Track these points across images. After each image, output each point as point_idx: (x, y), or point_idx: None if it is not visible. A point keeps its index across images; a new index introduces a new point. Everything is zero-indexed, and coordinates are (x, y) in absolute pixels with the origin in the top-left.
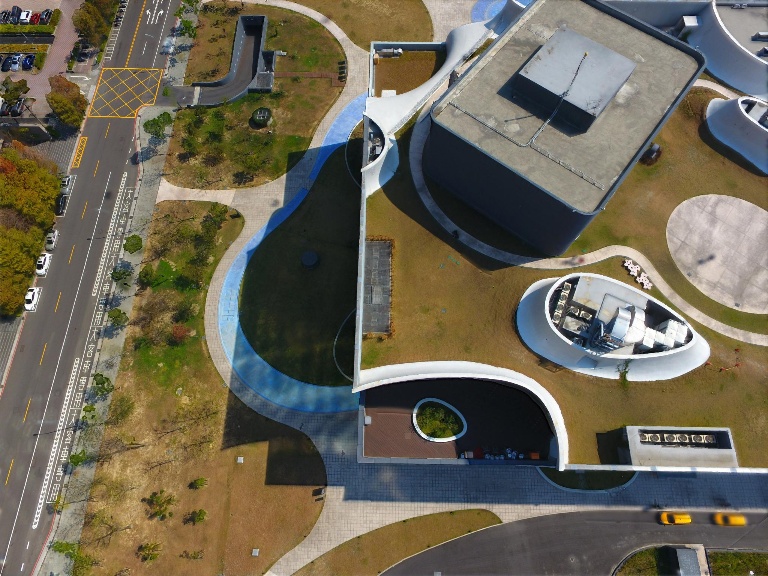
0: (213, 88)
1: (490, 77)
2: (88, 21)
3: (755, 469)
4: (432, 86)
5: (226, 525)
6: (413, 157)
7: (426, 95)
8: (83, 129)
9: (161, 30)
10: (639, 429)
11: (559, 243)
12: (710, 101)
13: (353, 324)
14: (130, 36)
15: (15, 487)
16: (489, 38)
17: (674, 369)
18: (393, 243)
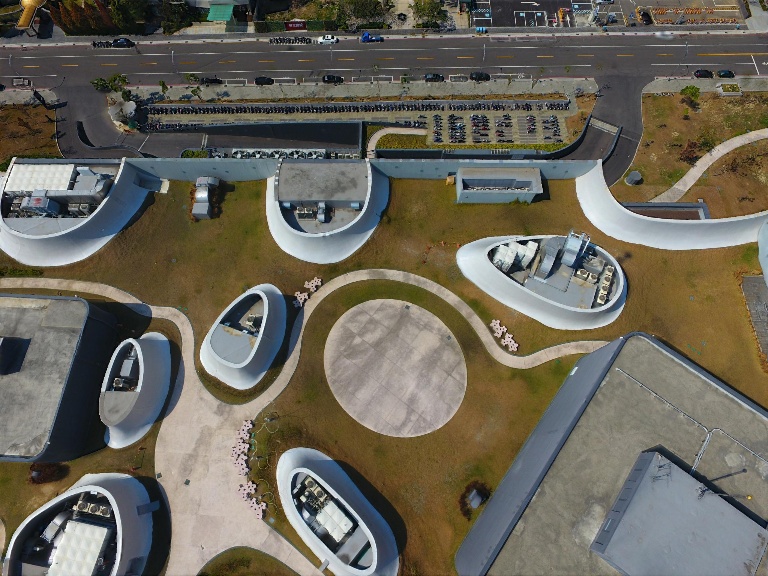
0: None
1: None
2: None
3: (455, 162)
4: None
5: None
6: None
7: None
8: None
9: None
10: (533, 191)
11: None
12: None
13: None
14: None
15: None
16: None
17: None
18: None
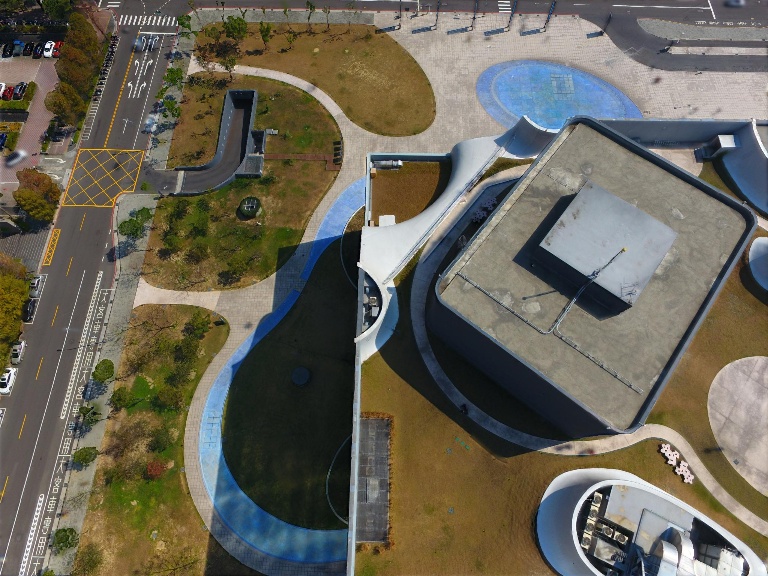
0: (198, 172)
1: (505, 238)
2: (62, 103)
3: None
4: (436, 216)
5: None
6: (415, 307)
7: (429, 227)
8: (56, 220)
9: (143, 105)
10: None
11: None
12: (753, 241)
13: (348, 454)
14: (110, 112)
15: None
16: (500, 157)
17: None
18: (392, 424)
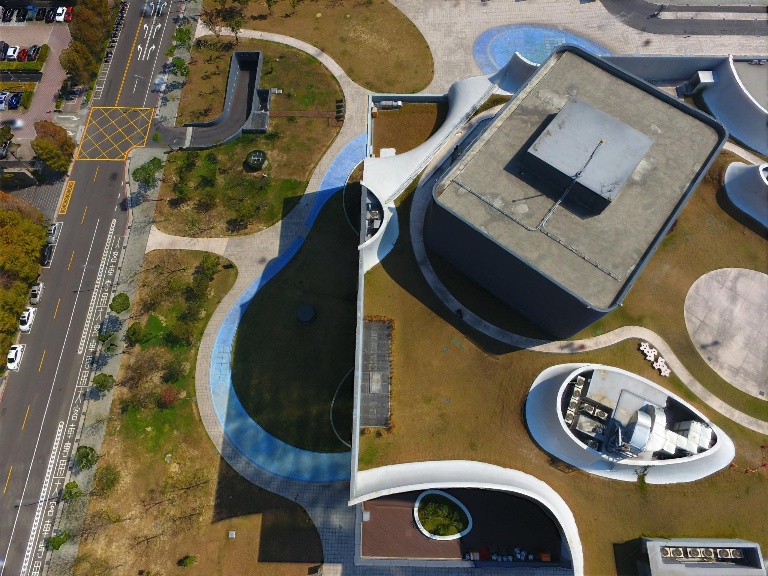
0: (206, 128)
1: (496, 150)
2: (76, 61)
3: None
4: (434, 146)
5: None
6: (414, 226)
7: (427, 156)
8: (71, 173)
9: (153, 66)
10: (660, 545)
11: (571, 329)
12: (728, 165)
13: (351, 384)
14: (120, 73)
15: None
16: (493, 93)
17: (696, 471)
18: (393, 325)
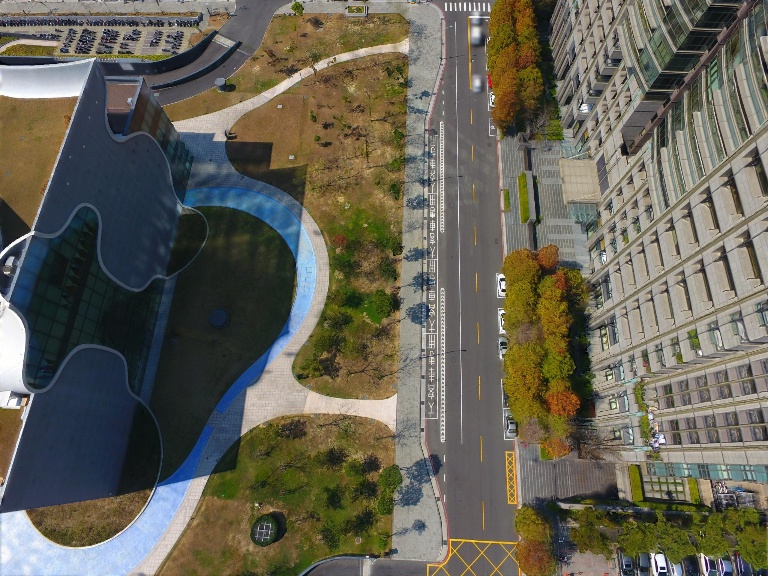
0: None
1: None
2: None
3: None
4: None
5: (302, 121)
6: None
7: None
8: None
9: None
10: None
11: None
12: None
13: (186, 255)
14: None
15: (465, 144)
16: None
17: None
18: (42, 188)
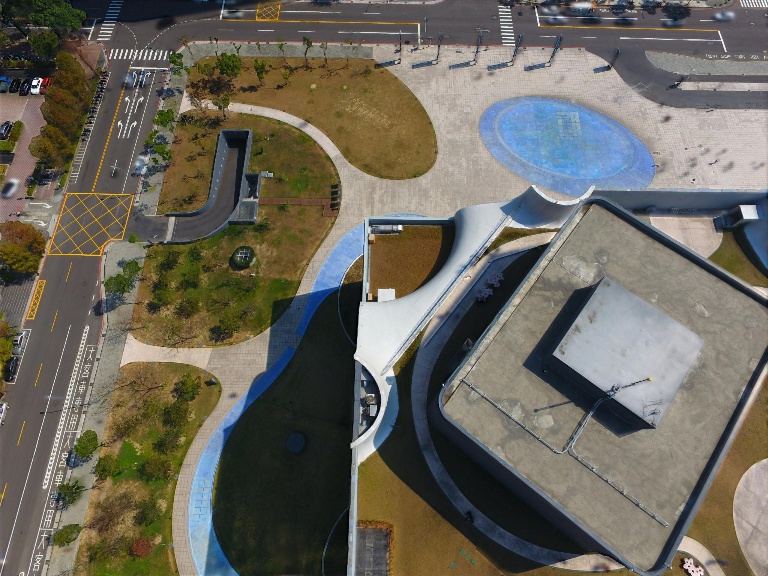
0: (190, 218)
1: (514, 339)
2: (48, 149)
3: None
4: (438, 293)
5: None
6: (416, 398)
7: (431, 306)
8: (41, 270)
9: (133, 146)
10: None
11: (603, 555)
12: None
13: (345, 529)
14: (99, 153)
15: None
16: (506, 226)
17: None
18: (391, 535)
